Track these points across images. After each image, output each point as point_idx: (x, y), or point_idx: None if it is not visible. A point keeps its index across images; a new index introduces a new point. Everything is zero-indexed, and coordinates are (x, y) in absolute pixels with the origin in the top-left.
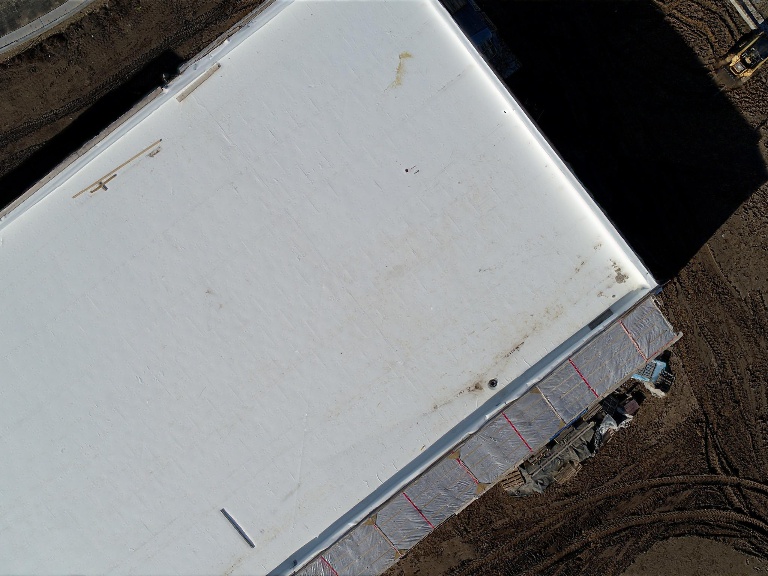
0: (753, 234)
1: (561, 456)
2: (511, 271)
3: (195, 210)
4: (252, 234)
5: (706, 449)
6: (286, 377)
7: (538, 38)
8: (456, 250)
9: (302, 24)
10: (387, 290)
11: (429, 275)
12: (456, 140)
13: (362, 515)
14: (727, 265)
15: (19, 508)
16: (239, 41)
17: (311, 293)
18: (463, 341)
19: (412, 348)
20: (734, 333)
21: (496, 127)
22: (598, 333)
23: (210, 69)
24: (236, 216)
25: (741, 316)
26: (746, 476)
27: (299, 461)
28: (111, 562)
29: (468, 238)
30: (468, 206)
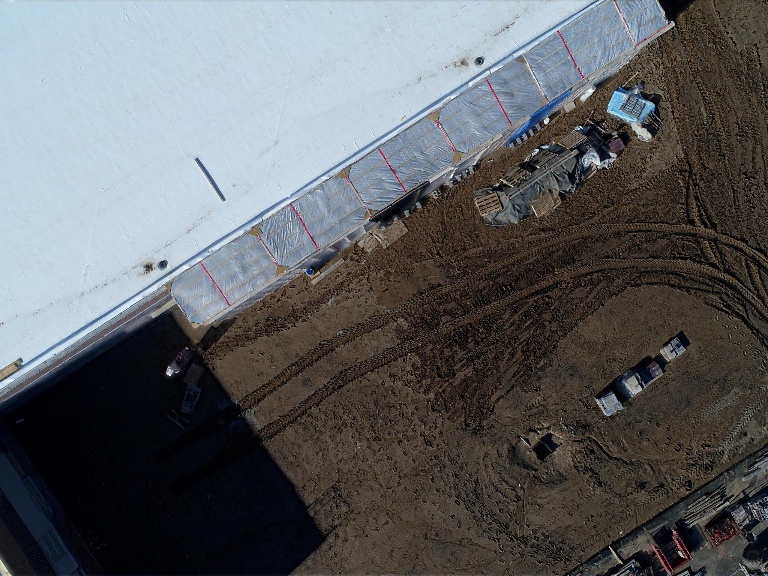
0: None
1: (541, 181)
2: None
3: None
4: None
5: (687, 199)
6: (273, 31)
7: None
8: None
9: None
10: None
11: None
12: None
13: (336, 170)
14: (726, 15)
15: None
16: None
17: None
18: (454, 14)
19: (402, 16)
20: (726, 85)
21: None
22: None
23: None
24: None
25: (735, 69)
26: (724, 231)
27: (278, 118)
28: (81, 200)
29: None
30: None
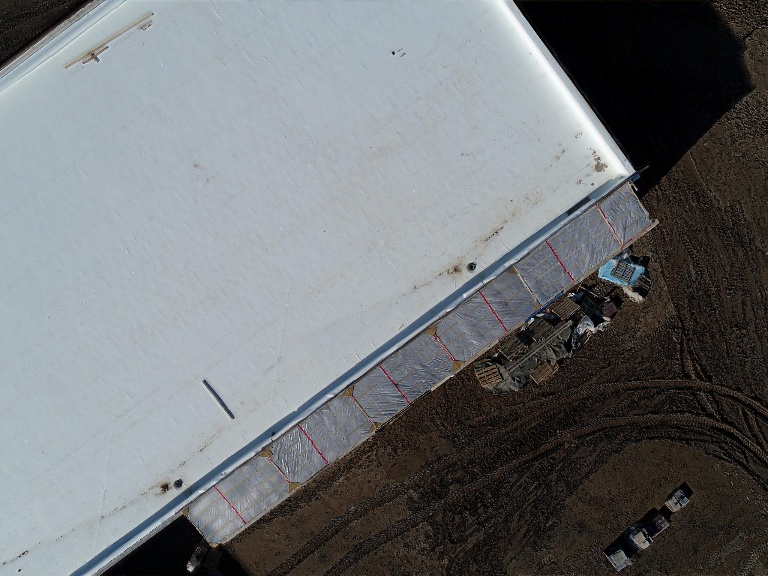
0: (735, 144)
1: (538, 353)
2: (493, 156)
3: (185, 85)
4: (240, 111)
5: (681, 355)
6: (270, 253)
7: None
8: (440, 134)
9: None
10: (371, 171)
11: (412, 157)
12: (443, 24)
13: (339, 387)
14: (708, 174)
15: (6, 372)
16: None
17: (296, 171)
18: (444, 224)
19: (394, 229)
20: (713, 241)
21: (483, 13)
22: (575, 217)
23: None
24: (225, 92)
25: (720, 225)
26: (719, 383)
27: (280, 336)
28: (94, 428)
29: (452, 122)
30: (453, 90)
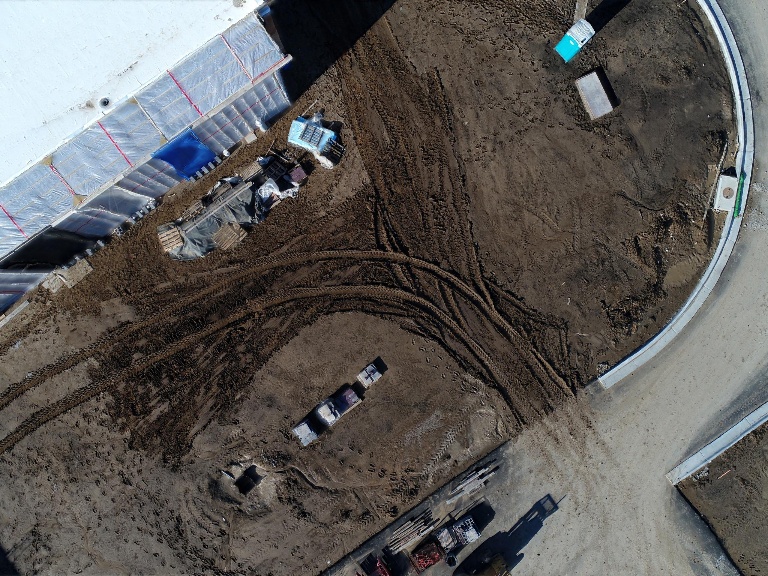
0: (431, 9)
1: (217, 215)
2: None
3: None
4: None
5: (375, 225)
6: None
7: None
8: None
9: None
10: None
11: None
12: None
13: None
14: (404, 39)
15: None
16: None
17: None
18: (75, 56)
19: (22, 60)
20: (408, 109)
21: None
22: None
23: None
24: None
25: (417, 92)
26: (416, 255)
27: None
28: None
29: None
30: None
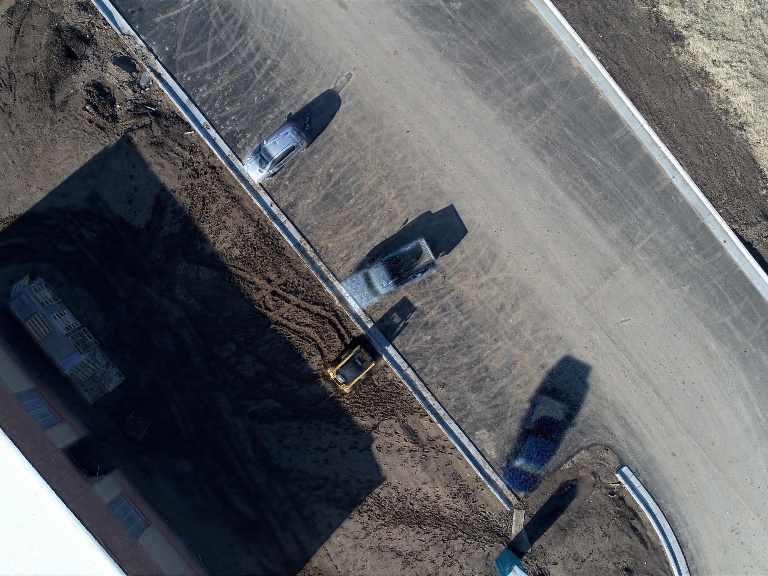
0: (369, 536)
1: None
2: None
3: None
4: None
5: None
6: None
7: (143, 350)
8: None
9: None
10: None
11: None
12: None
13: None
14: (344, 567)
15: None
16: None
17: None
18: None
19: None
20: None
21: (34, 497)
22: None
23: None
24: None
25: None
26: None
27: None
28: None
29: None
30: (10, 575)
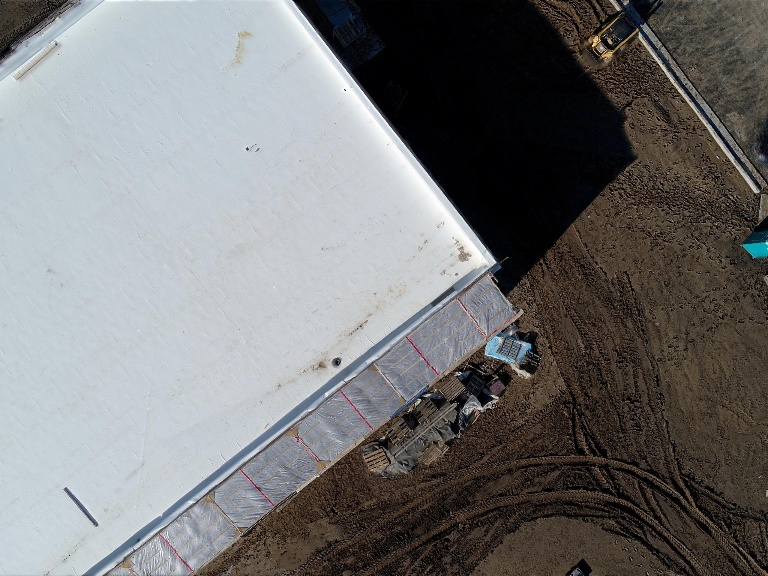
0: (619, 215)
1: (424, 437)
2: (354, 249)
3: (34, 188)
4: (92, 212)
5: (574, 430)
6: (128, 356)
7: (402, 19)
8: (298, 228)
9: (140, 2)
10: (229, 268)
11: (271, 253)
12: (297, 118)
13: (201, 493)
14: (593, 246)
15: None
16: (75, 19)
17: (152, 271)
18: (306, 319)
19: (255, 326)
20: (601, 314)
21: (337, 105)
22: (437, 311)
23: (47, 47)
24: (76, 194)
25: (608, 297)
26: (614, 457)
27: (142, 440)
28: None
29: (310, 216)
30: (309, 184)
